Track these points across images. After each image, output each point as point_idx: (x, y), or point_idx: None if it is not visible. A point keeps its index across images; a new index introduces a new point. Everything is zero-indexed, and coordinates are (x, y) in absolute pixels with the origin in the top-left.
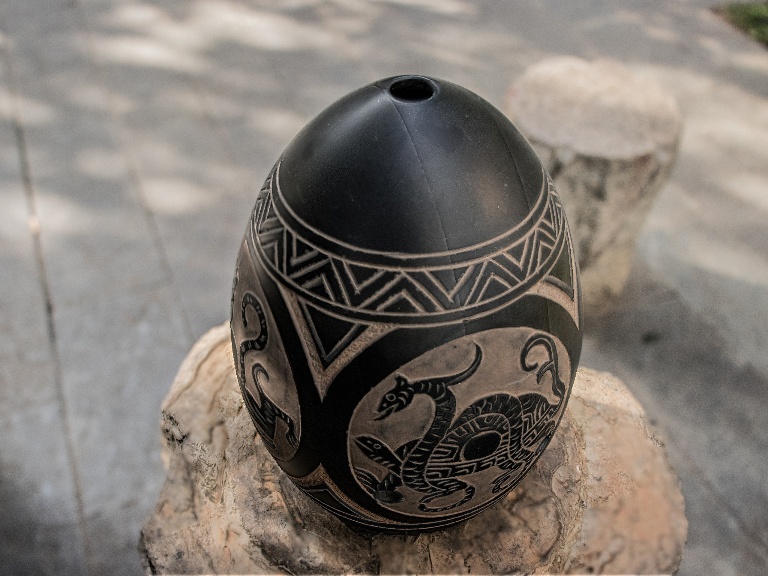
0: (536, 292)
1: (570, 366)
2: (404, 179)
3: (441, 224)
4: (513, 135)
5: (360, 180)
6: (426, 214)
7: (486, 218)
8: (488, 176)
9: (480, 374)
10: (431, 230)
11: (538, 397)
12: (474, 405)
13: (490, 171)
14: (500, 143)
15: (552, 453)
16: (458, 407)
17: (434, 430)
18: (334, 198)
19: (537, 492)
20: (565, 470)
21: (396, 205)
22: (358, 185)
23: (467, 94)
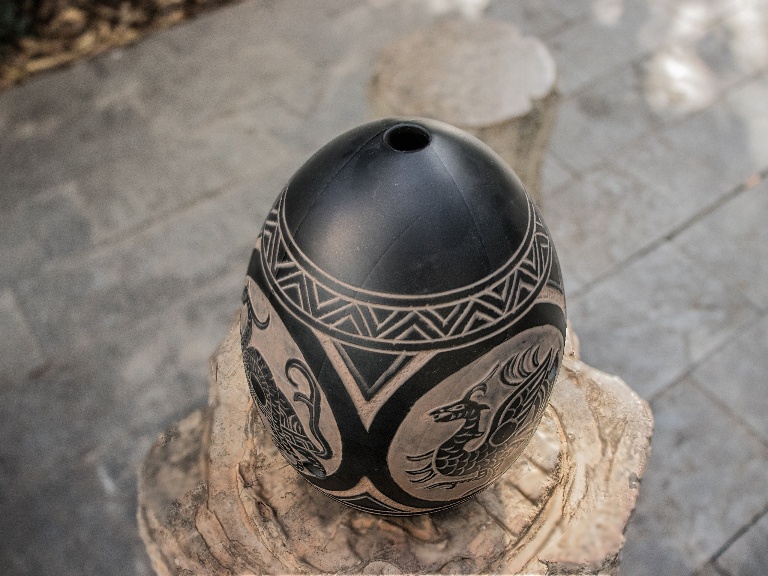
0: (322, 339)
1: (342, 441)
2: (323, 174)
3: (304, 219)
4: (427, 241)
5: (322, 153)
6: (306, 204)
7: (323, 248)
8: (353, 228)
9: (264, 336)
10: (299, 216)
11: (293, 411)
12: (256, 351)
13: (358, 228)
14: (395, 226)
15: (412, 559)
16: (252, 340)
17: (244, 338)
18: (316, 152)
19: (365, 547)
20: (396, 574)
21: (307, 183)
22: (319, 155)
23: (436, 181)
